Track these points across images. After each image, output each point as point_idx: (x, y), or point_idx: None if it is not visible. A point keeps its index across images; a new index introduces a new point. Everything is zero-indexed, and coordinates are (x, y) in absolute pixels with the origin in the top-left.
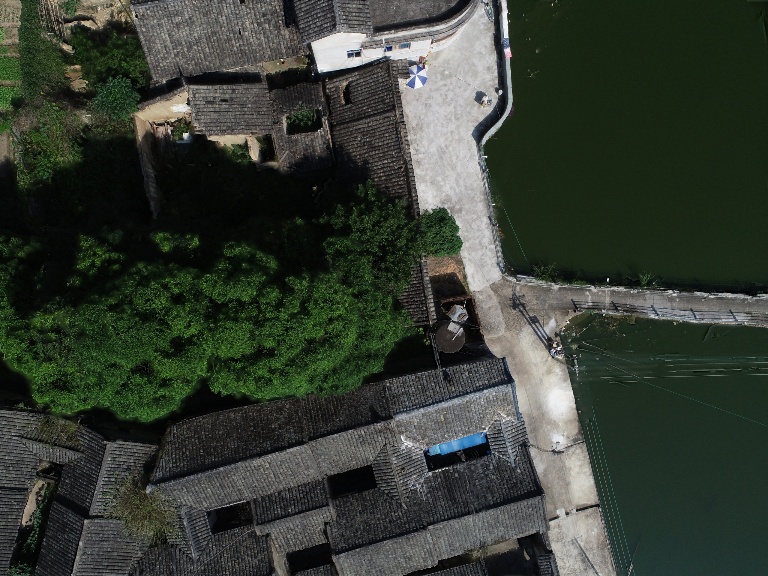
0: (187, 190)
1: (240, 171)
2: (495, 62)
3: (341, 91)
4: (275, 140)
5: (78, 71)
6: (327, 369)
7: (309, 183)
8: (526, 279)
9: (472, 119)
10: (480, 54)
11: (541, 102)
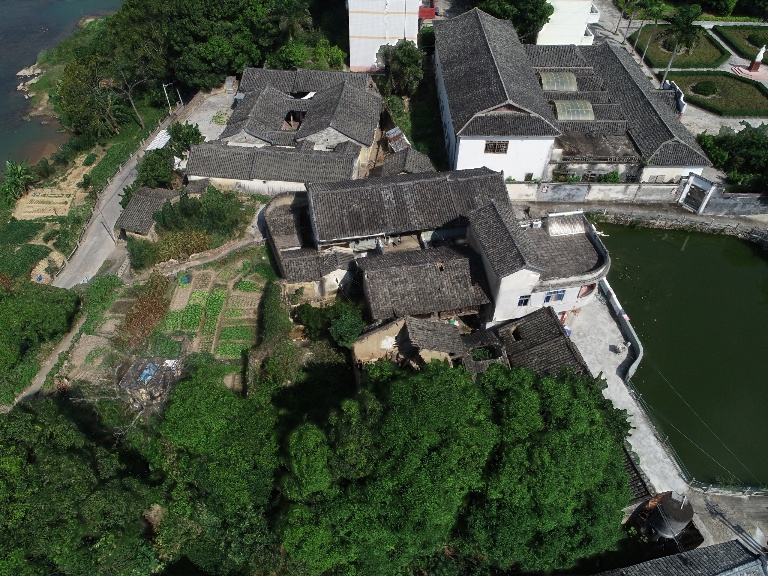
0: None
1: None
2: (616, 327)
3: (511, 333)
4: (465, 365)
5: (299, 331)
6: (580, 507)
7: None
8: (712, 490)
9: (612, 363)
10: (603, 323)
11: (661, 355)
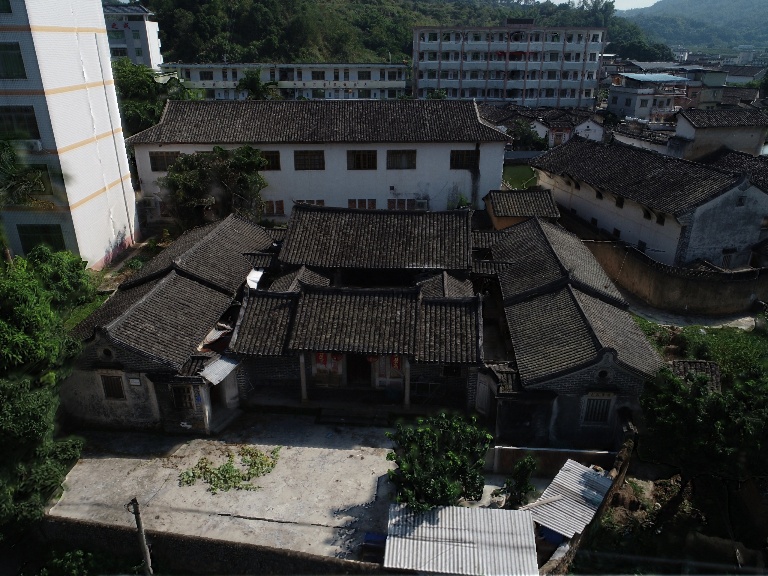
0: None
1: None
2: None
3: None
4: None
5: None
6: None
7: None
8: None
9: None
10: None
11: None
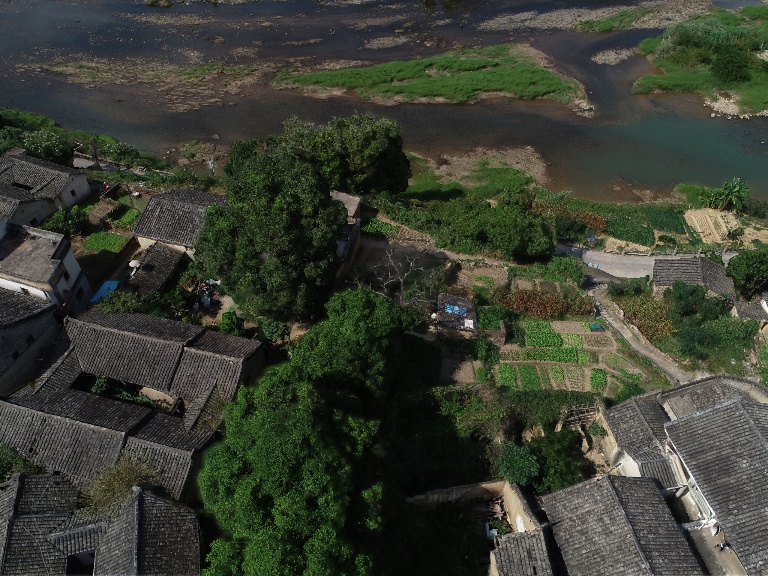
0: (439, 534)
1: None
2: None
3: None
4: None
5: (540, 435)
6: None
7: None
8: None
9: None
10: None
11: None
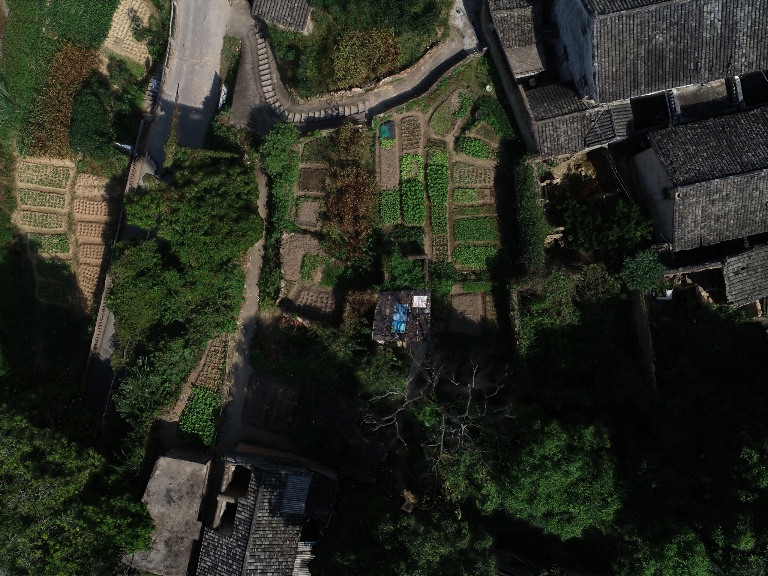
0: None
1: (725, 326)
2: None
3: None
4: (767, 297)
5: None
6: None
7: (767, 327)
8: None
9: None
10: None
11: None
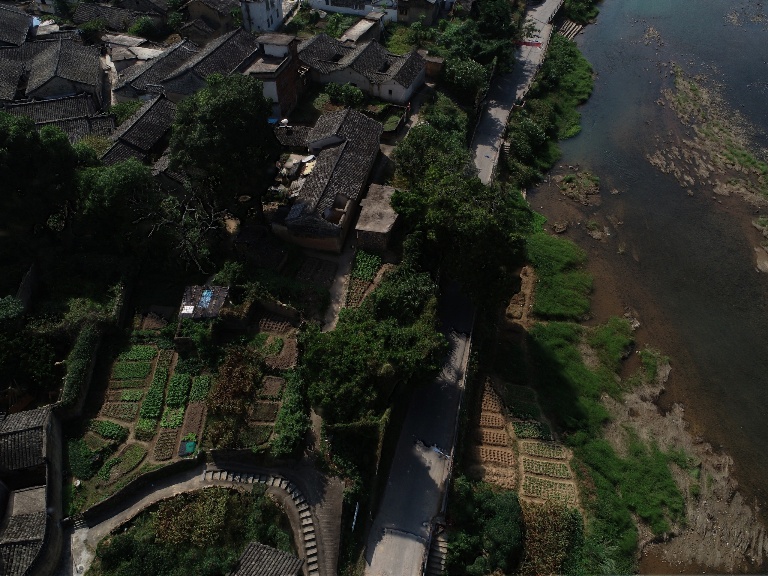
0: None
1: None
2: None
3: None
4: None
5: None
6: None
7: None
8: None
9: None
10: None
11: None
